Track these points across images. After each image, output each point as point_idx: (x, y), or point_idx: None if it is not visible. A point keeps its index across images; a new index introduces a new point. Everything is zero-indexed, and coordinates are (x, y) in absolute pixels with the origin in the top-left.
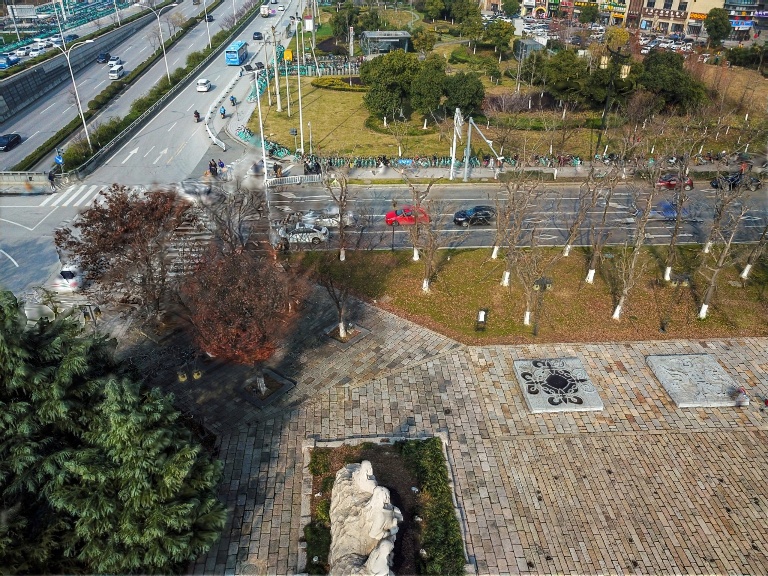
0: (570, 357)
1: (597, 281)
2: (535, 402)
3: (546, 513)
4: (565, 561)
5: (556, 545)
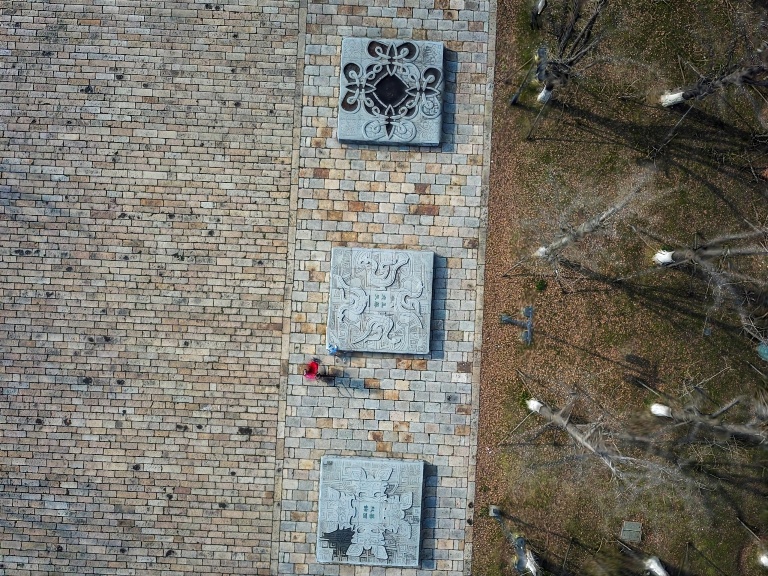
0: (455, 141)
1: (663, 275)
2: (354, 45)
3: (188, 6)
4: (130, 6)
5: (149, 3)
